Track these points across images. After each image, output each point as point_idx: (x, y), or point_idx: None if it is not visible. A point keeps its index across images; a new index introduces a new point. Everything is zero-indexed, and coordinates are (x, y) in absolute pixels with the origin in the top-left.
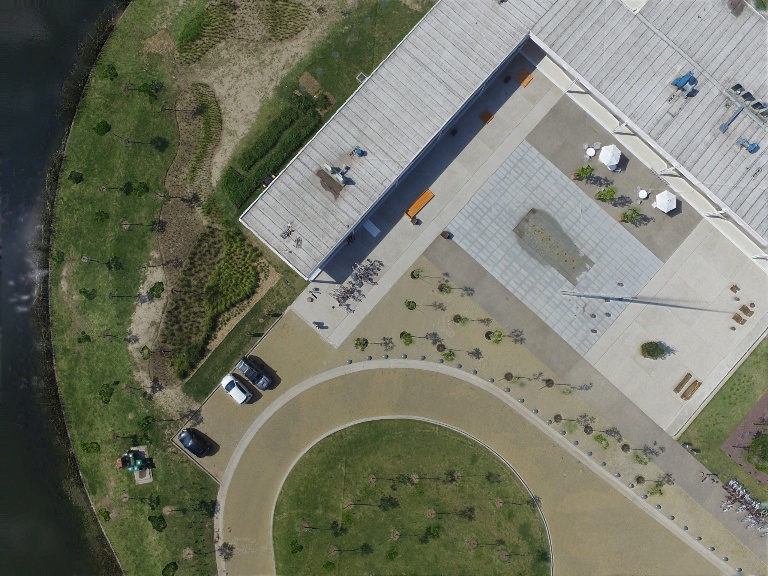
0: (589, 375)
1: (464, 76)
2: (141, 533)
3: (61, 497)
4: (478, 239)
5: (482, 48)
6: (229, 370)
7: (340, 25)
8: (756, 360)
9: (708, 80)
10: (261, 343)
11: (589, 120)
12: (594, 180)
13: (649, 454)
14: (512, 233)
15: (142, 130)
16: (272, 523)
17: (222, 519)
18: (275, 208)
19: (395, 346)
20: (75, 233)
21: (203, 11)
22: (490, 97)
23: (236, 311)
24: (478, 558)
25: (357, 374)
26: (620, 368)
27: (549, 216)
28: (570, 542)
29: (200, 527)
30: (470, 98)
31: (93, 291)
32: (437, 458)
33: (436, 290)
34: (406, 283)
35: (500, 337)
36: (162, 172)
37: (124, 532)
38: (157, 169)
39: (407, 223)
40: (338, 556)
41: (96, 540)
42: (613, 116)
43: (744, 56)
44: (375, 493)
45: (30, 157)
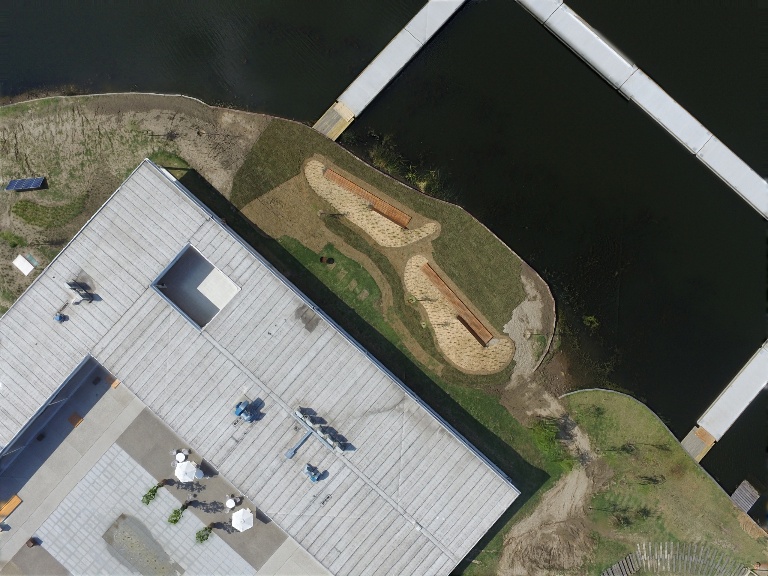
0: None
1: (22, 400)
2: None
3: None
4: (67, 545)
5: (41, 371)
6: None
7: None
8: None
9: (276, 402)
10: None
11: None
12: (186, 485)
13: None
14: (101, 539)
15: None
16: None
17: None
18: None
19: None
20: None
21: None
22: (80, 399)
23: None
24: None
25: None
26: None
27: (139, 522)
28: None
29: None
30: (29, 422)
31: None
32: None
33: None
34: None
35: None
36: None
37: None
38: None
39: None
40: None
41: None
42: None
43: (316, 375)
44: None
45: None
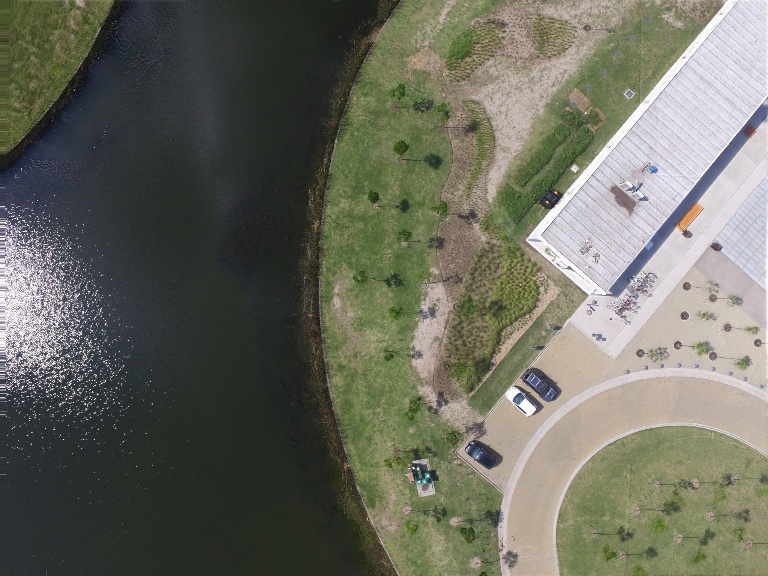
0: None
1: (747, 93)
2: (424, 544)
3: (336, 511)
4: (745, 250)
5: (762, 66)
6: (512, 383)
7: (606, 42)
8: None
9: None
10: (542, 356)
11: None
12: None
13: None
14: None
15: (415, 148)
16: (555, 530)
17: (506, 528)
18: (573, 225)
19: (670, 356)
20: (347, 251)
21: (469, 29)
22: None
23: (518, 325)
24: (753, 557)
25: (635, 384)
26: None
27: None
28: None
29: (486, 537)
30: (752, 114)
31: (400, 309)
32: (714, 463)
33: (707, 300)
34: (679, 294)
35: None
36: (438, 189)
37: (405, 544)
38: (432, 186)
39: (678, 236)
40: (625, 560)
41: (372, 552)
42: None
43: None
44: (659, 498)
45: (291, 175)
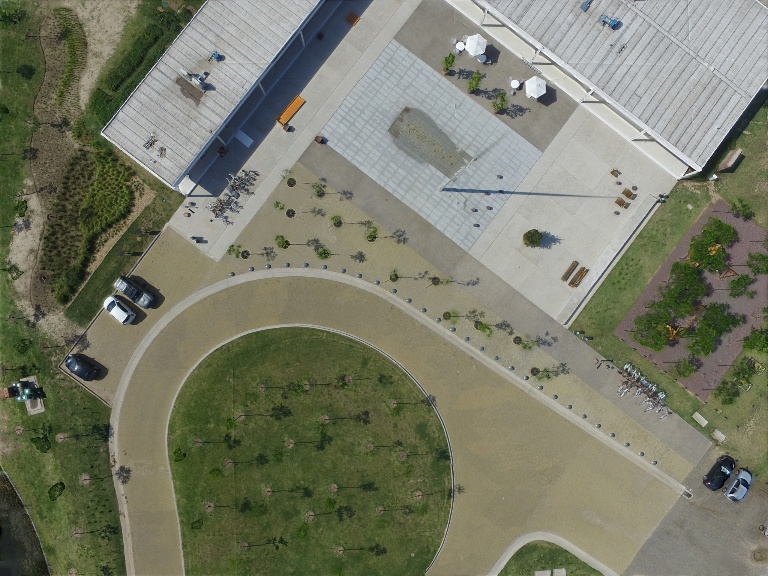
0: (475, 270)
1: None
2: (38, 464)
3: None
4: (353, 142)
5: None
6: (111, 292)
7: None
8: (643, 243)
9: None
10: (141, 262)
11: (457, 15)
12: (466, 74)
13: (541, 345)
14: (387, 133)
15: (7, 59)
16: (167, 442)
17: (116, 443)
18: (136, 119)
19: (277, 255)
20: None
21: None
22: None
23: (113, 232)
24: (376, 461)
25: (240, 286)
26: (506, 261)
27: (423, 114)
28: (468, 439)
29: (94, 452)
30: None
31: None
32: (326, 363)
33: (314, 196)
34: (283, 191)
35: (375, 233)
36: (30, 99)
37: (21, 465)
38: (25, 97)
39: (280, 131)
40: (233, 468)
41: None
42: (479, 8)
43: None
44: (266, 403)
45: None
